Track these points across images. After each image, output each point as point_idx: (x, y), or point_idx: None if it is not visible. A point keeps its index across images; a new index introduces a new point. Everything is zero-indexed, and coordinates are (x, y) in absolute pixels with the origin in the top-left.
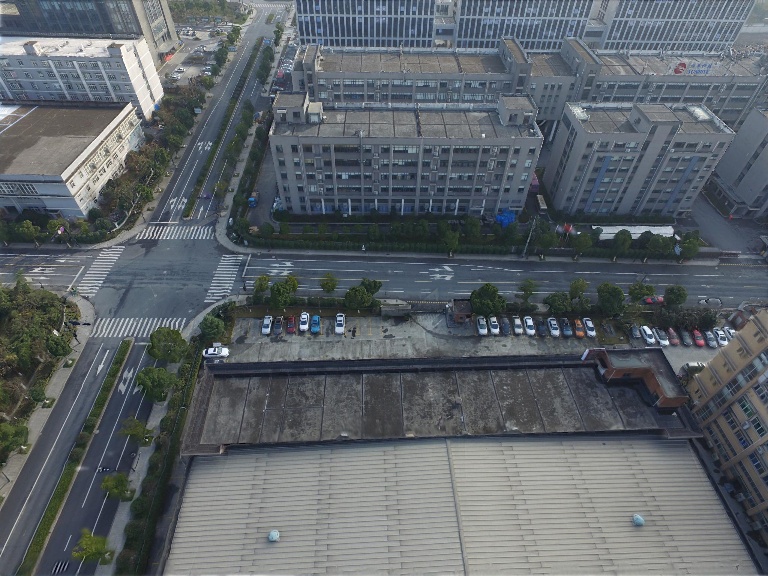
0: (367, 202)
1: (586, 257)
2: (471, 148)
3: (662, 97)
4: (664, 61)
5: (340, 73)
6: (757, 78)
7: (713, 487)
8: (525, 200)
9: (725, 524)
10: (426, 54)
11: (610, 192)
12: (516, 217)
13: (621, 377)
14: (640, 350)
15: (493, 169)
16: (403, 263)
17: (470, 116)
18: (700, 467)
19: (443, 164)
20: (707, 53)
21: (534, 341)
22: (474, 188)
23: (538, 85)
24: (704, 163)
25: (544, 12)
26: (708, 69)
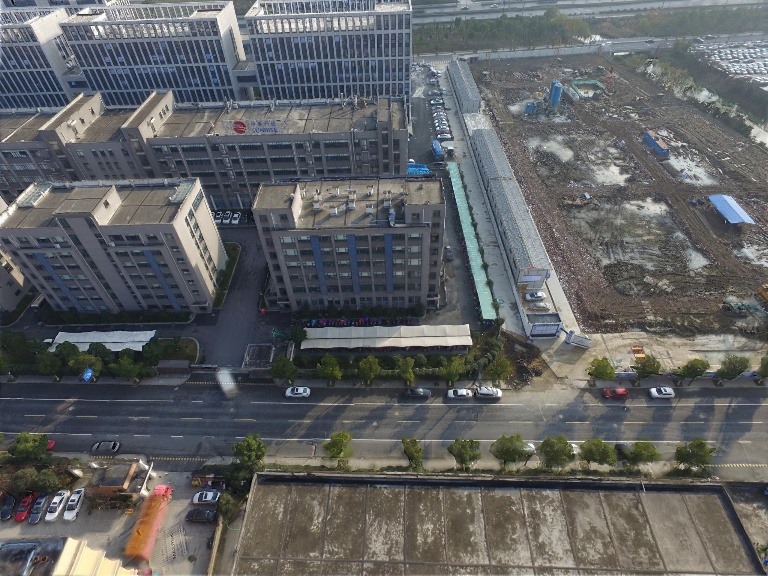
0: None
1: (28, 375)
2: None
3: (244, 159)
4: (268, 114)
5: None
6: (340, 134)
7: None
8: None
9: None
10: (4, 116)
11: (87, 289)
12: None
13: None
14: None
15: None
16: None
17: None
18: None
19: None
20: (331, 101)
21: None
22: None
23: (84, 152)
24: (164, 257)
25: (173, 59)
26: (274, 127)
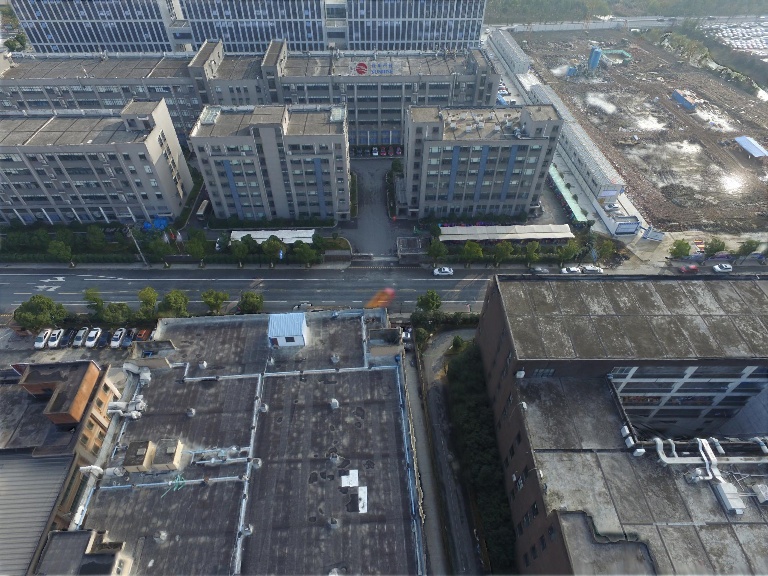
0: (7, 212)
1: (214, 263)
2: (77, 155)
3: (359, 98)
4: None
5: (11, 80)
6: (445, 77)
7: (52, 508)
8: (171, 206)
9: (27, 548)
10: (132, 59)
11: (253, 196)
12: (171, 224)
13: (45, 392)
14: (68, 364)
15: (115, 176)
16: (17, 275)
17: (103, 122)
18: (58, 486)
19: (60, 172)
20: (424, 52)
21: (88, 353)
22: (108, 195)
23: (222, 88)
24: (329, 165)
25: (274, 14)
26: (391, 69)
